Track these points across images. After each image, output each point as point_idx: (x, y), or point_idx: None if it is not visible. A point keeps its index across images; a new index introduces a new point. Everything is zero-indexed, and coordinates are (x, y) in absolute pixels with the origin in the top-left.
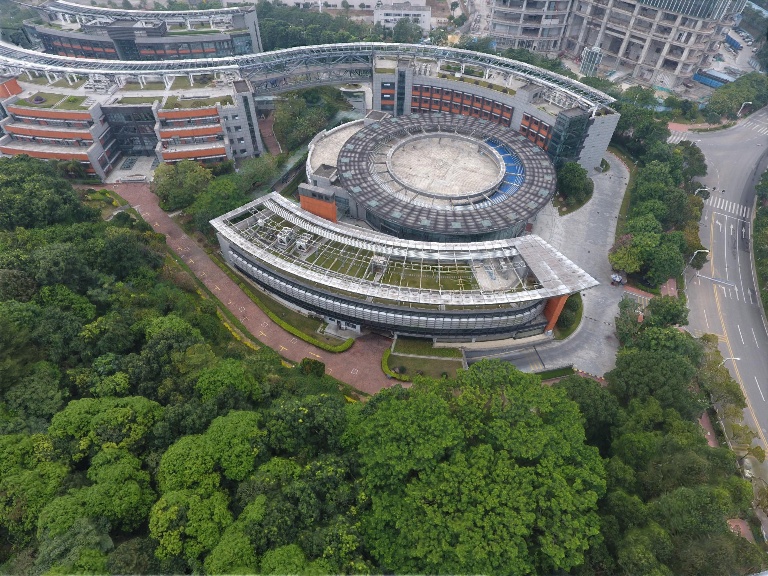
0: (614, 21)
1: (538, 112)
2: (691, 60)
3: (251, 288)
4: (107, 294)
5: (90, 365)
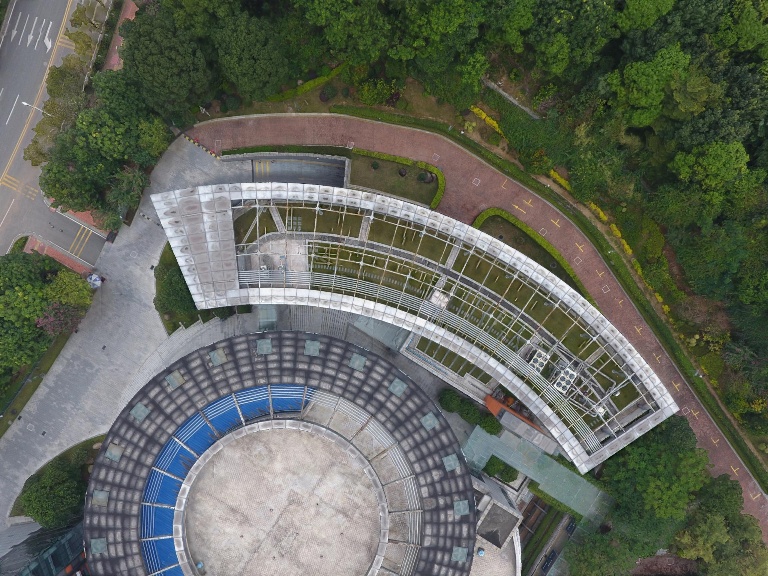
0: None
1: None
2: None
3: None
4: None
5: None
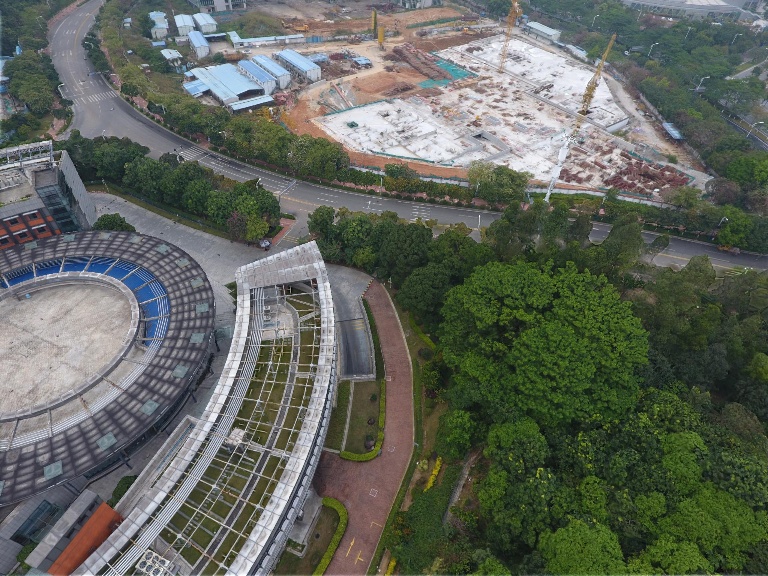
0: None
1: (4, 210)
2: None
3: None
4: None
5: None
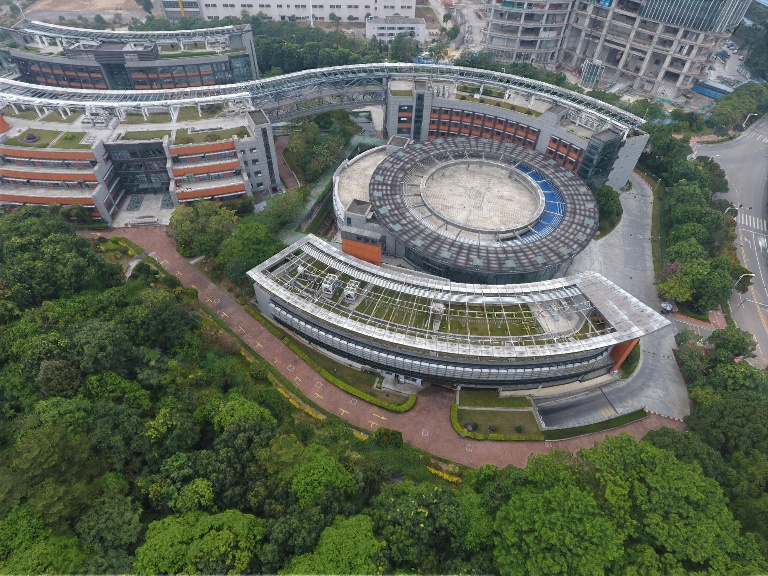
0: (612, 33)
1: (567, 135)
2: (692, 72)
3: (294, 342)
4: (158, 375)
5: (157, 468)
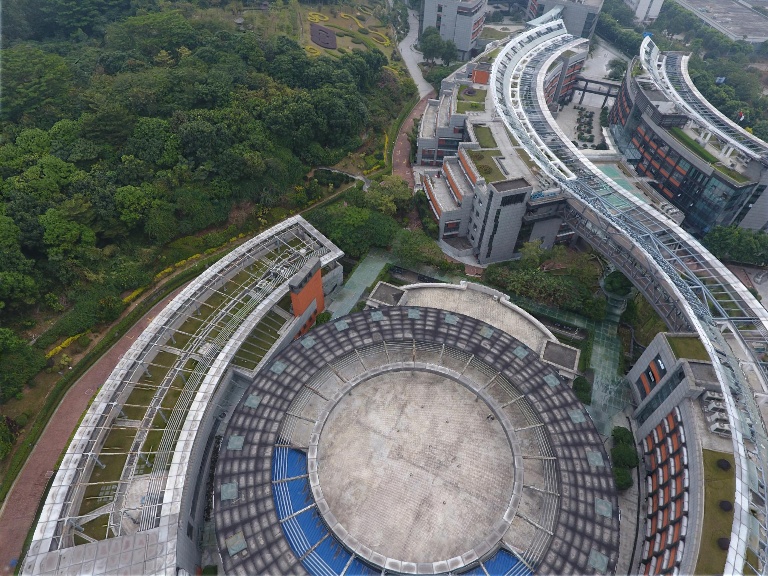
0: None
1: None
2: None
3: None
4: None
5: None
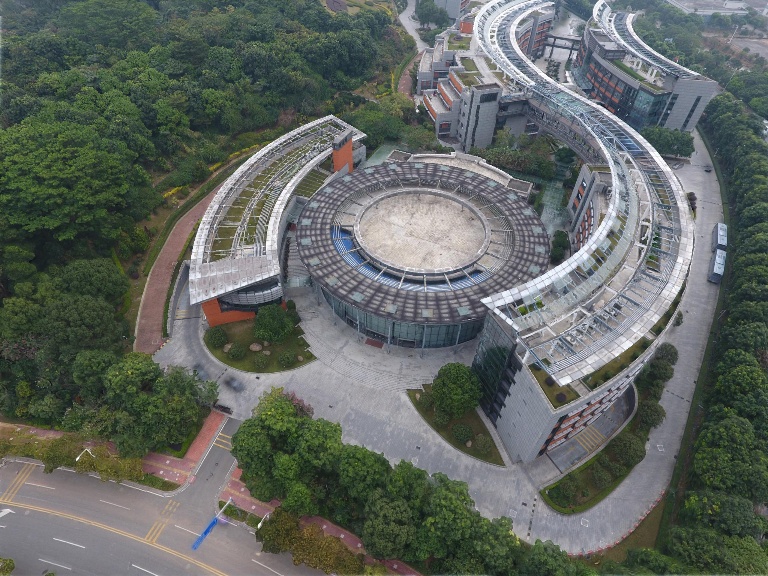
0: None
1: None
2: None
3: None
4: None
5: None
